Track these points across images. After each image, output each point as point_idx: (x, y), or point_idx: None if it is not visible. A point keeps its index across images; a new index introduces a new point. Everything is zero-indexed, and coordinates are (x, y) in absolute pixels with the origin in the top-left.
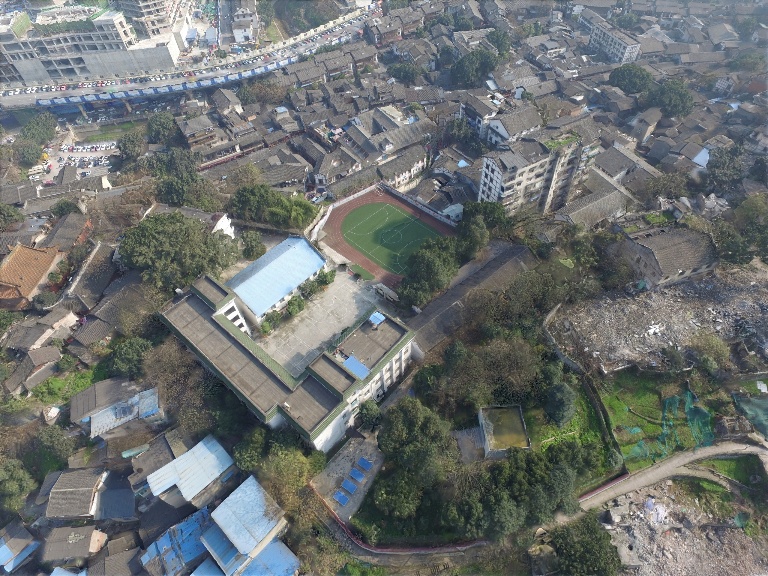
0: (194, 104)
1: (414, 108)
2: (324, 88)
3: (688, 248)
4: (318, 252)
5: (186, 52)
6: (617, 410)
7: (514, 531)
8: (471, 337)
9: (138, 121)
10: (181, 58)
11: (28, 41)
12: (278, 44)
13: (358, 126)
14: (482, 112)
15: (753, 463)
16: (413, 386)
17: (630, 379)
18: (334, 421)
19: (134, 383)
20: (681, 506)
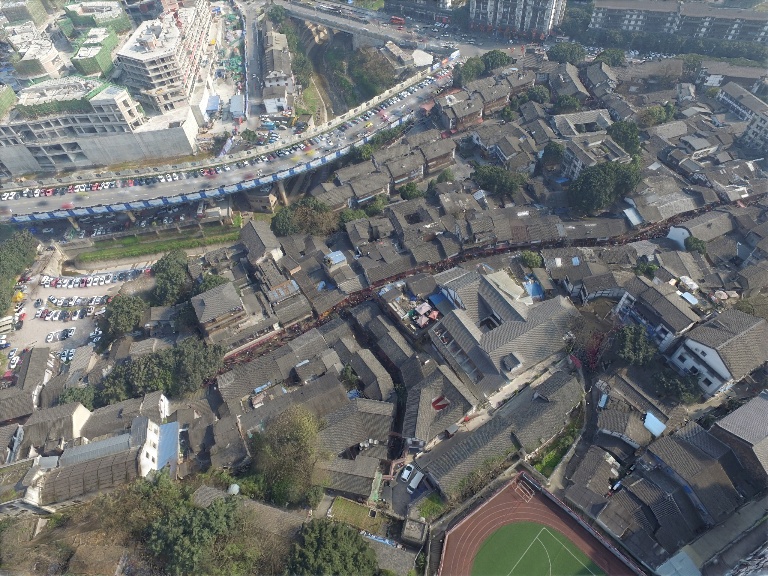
0: (215, 213)
1: (529, 262)
2: (393, 216)
3: None
4: None
5: (206, 128)
6: None
7: None
8: None
9: (143, 234)
10: (200, 137)
11: (10, 125)
12: (322, 126)
13: (459, 312)
14: (674, 323)
15: None
16: None
17: None
18: None
19: None
20: None
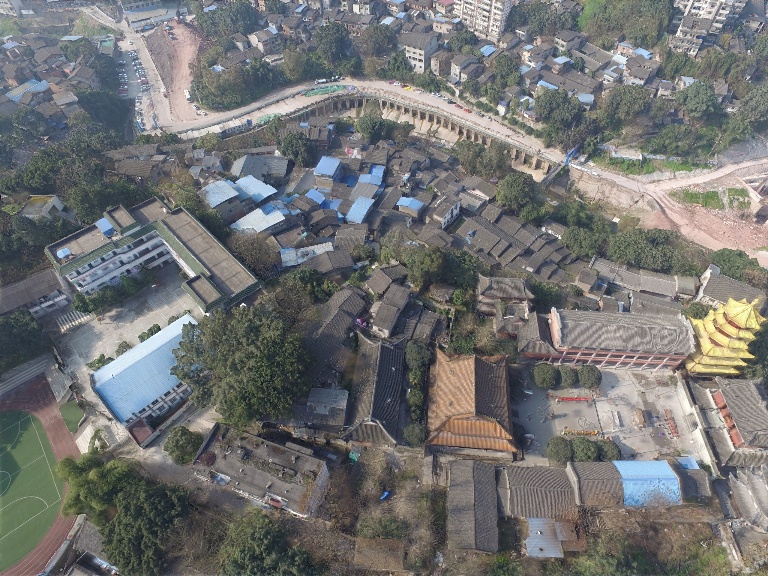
0: None
1: None
2: None
3: None
4: None
5: None
6: None
7: None
8: (6, 271)
9: None
10: None
11: None
12: None
13: None
14: None
15: None
16: None
17: None
18: None
19: None
20: None
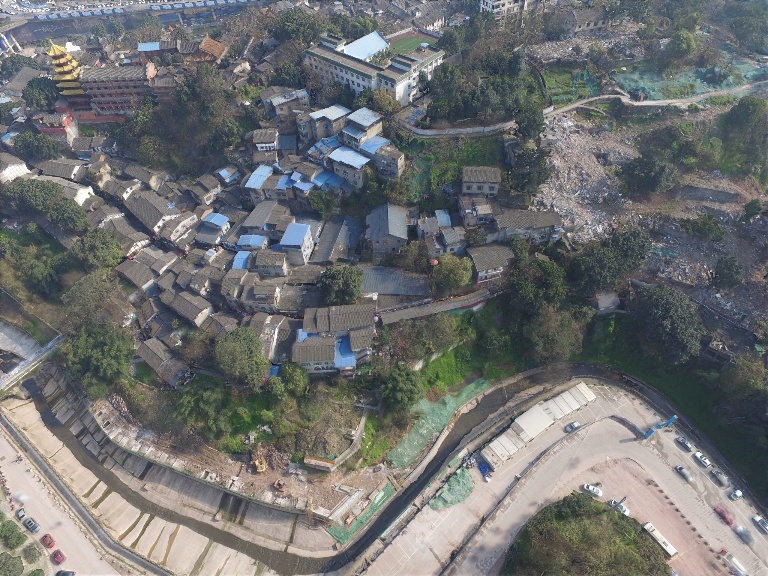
0: None
1: (433, 0)
2: None
3: (592, 12)
4: (384, 38)
5: None
6: (549, 80)
7: (495, 102)
8: None
9: None
10: None
11: None
12: None
13: None
14: None
15: (617, 102)
16: None
17: (557, 68)
18: (405, 84)
19: None
20: (580, 123)
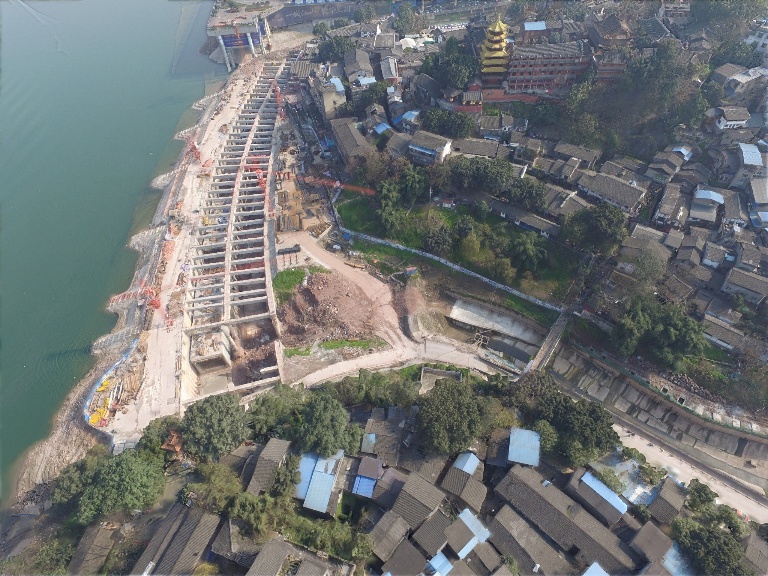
0: None
1: None
2: None
3: None
4: None
5: None
6: None
7: None
8: None
9: (462, 13)
10: None
11: None
12: None
13: None
14: None
15: None
16: None
17: None
18: None
19: (742, 66)
20: None
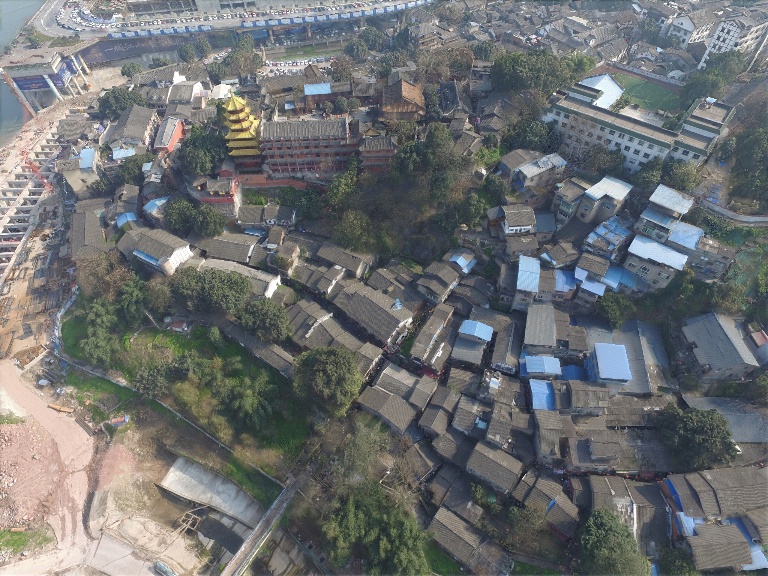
0: None
1: None
2: (499, 10)
3: None
4: None
5: None
6: None
7: None
8: (759, 121)
9: (318, 45)
10: None
11: None
12: None
13: None
14: (668, 13)
15: None
16: (736, 144)
17: None
18: None
19: (536, 152)
20: None
